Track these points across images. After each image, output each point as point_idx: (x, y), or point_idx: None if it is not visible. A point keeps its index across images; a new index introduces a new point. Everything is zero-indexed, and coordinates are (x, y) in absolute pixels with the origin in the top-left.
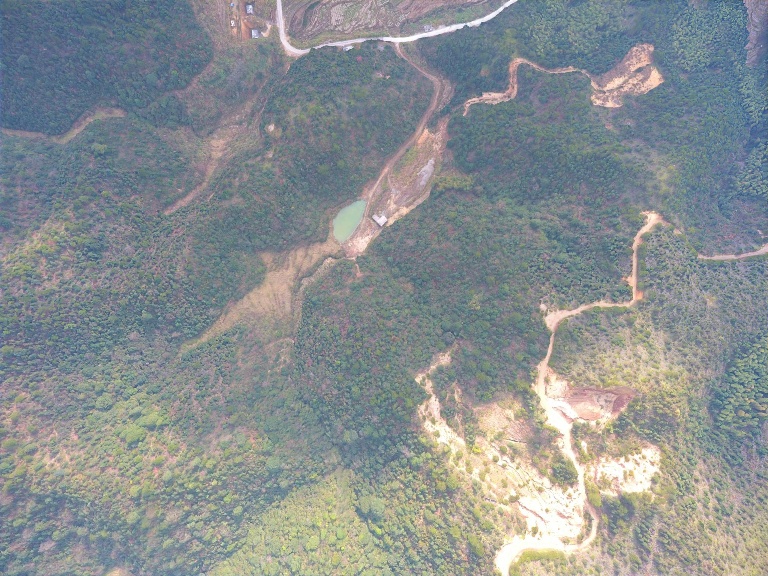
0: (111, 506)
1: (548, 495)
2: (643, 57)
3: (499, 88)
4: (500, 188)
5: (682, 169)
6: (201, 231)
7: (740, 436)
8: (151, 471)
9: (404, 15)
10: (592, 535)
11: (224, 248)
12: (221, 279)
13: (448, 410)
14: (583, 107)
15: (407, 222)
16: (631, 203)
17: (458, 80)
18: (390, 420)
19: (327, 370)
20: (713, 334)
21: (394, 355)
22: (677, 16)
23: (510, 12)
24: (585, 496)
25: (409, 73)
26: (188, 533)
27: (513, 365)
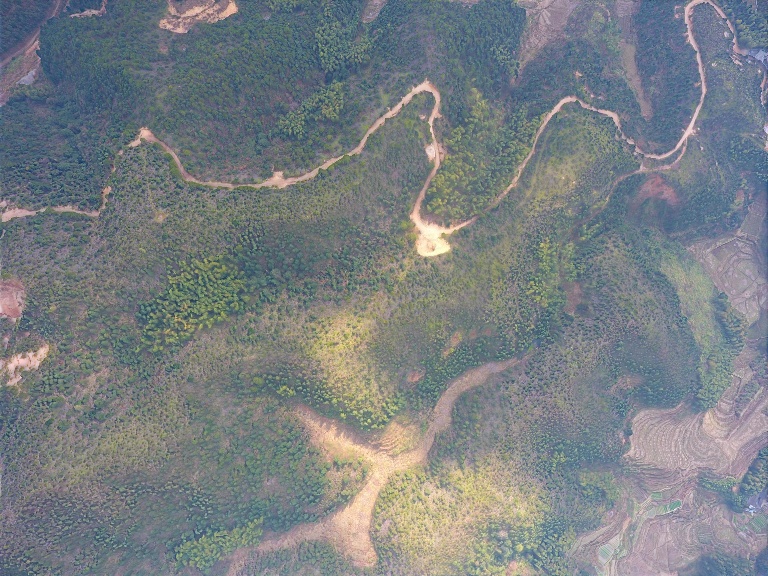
0: None
1: None
2: None
3: (95, 5)
4: (66, 100)
5: (185, 91)
6: None
7: (162, 353)
8: None
9: None
10: None
11: None
12: None
13: None
14: (137, 26)
15: None
16: (137, 119)
17: None
18: None
19: None
20: (135, 245)
21: None
22: None
23: None
24: None
25: None
26: None
27: None
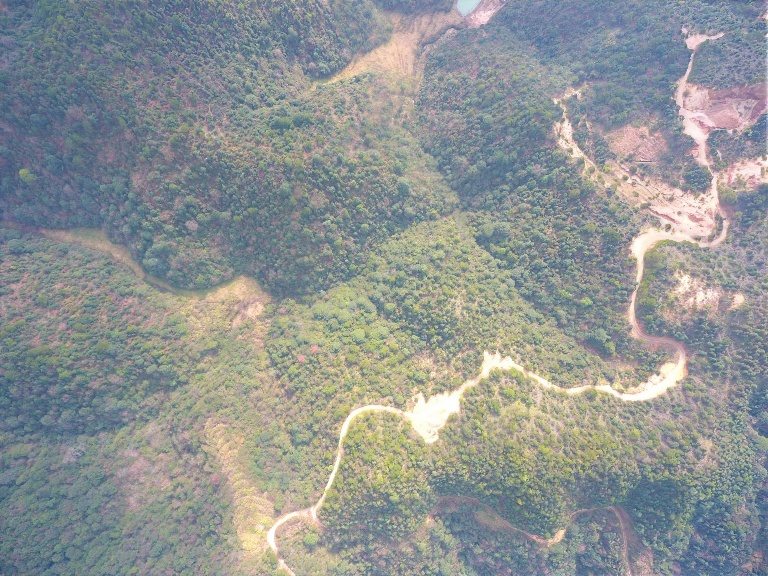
0: (265, 175)
1: (680, 202)
2: None
3: None
4: None
5: None
6: None
7: None
8: None
9: None
10: (722, 235)
11: None
12: (356, 22)
13: (581, 133)
14: None
15: None
16: None
17: None
18: (524, 139)
19: (453, 113)
20: None
21: (530, 82)
22: None
23: None
24: (717, 200)
25: None
26: (323, 231)
27: (649, 88)
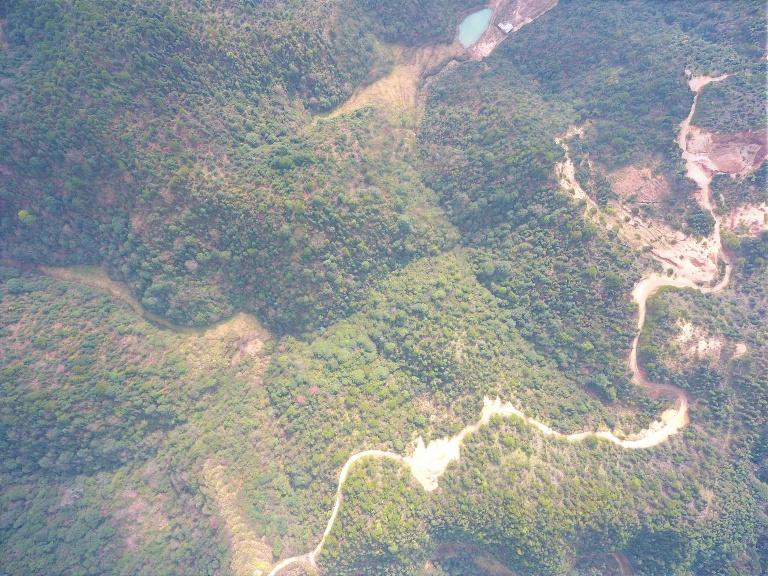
0: (265, 217)
1: (682, 245)
2: None
3: None
4: None
5: None
6: (346, 3)
7: None
8: (302, 193)
9: None
10: (725, 281)
11: (362, 27)
12: (358, 56)
13: (583, 173)
14: None
15: (537, 24)
16: None
17: None
18: (526, 179)
19: (455, 149)
20: None
21: (532, 120)
22: None
23: None
24: (720, 245)
25: None
26: (323, 270)
27: (652, 129)
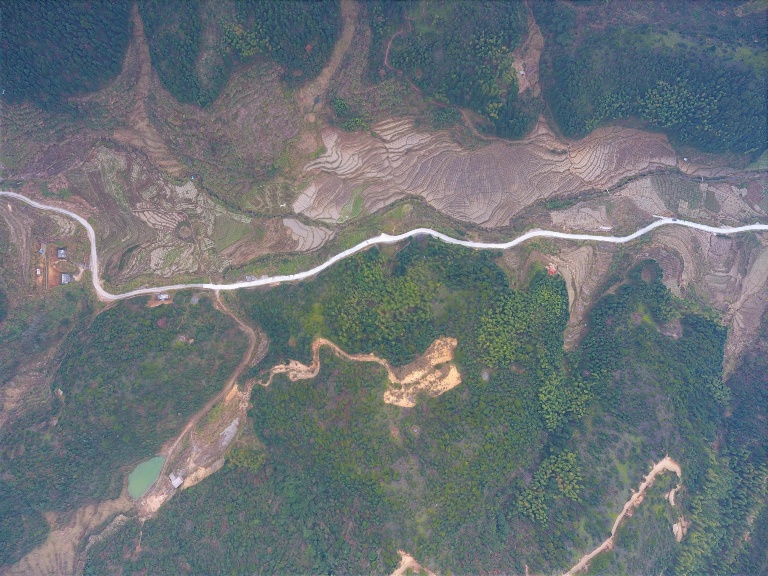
0: None
1: None
2: (445, 351)
3: (304, 361)
4: (288, 474)
5: (443, 510)
6: None
7: None
8: None
9: (228, 261)
10: None
11: None
12: None
13: None
14: (368, 412)
15: (194, 496)
16: (392, 536)
17: (271, 339)
18: None
19: None
20: None
21: None
22: (491, 303)
23: (325, 280)
24: None
25: (220, 331)
26: None
27: None
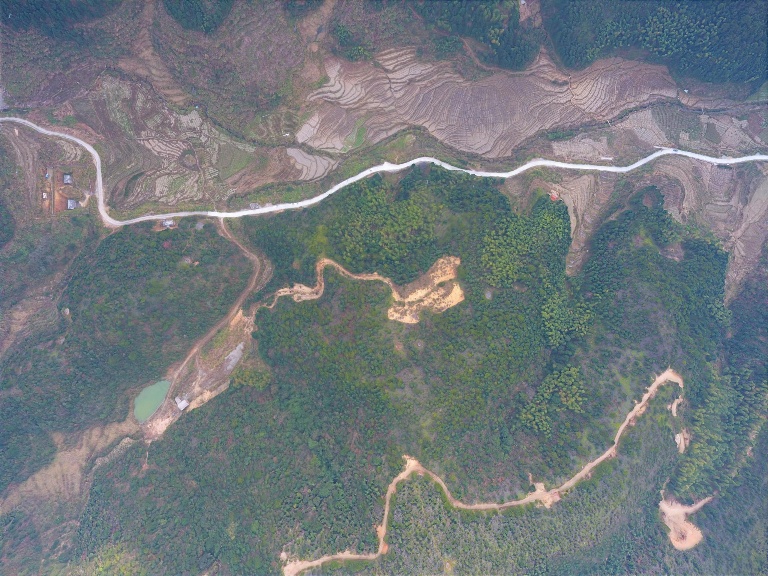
0: None
1: None
2: (448, 270)
3: (308, 283)
4: (293, 392)
5: (448, 415)
6: None
7: None
8: None
9: (232, 189)
10: None
11: (4, 435)
12: None
13: None
14: (373, 326)
15: (200, 415)
16: (397, 442)
17: (275, 265)
18: None
19: (94, 571)
20: None
21: None
22: (493, 224)
23: (329, 204)
24: None
25: (224, 256)
26: None
27: None
